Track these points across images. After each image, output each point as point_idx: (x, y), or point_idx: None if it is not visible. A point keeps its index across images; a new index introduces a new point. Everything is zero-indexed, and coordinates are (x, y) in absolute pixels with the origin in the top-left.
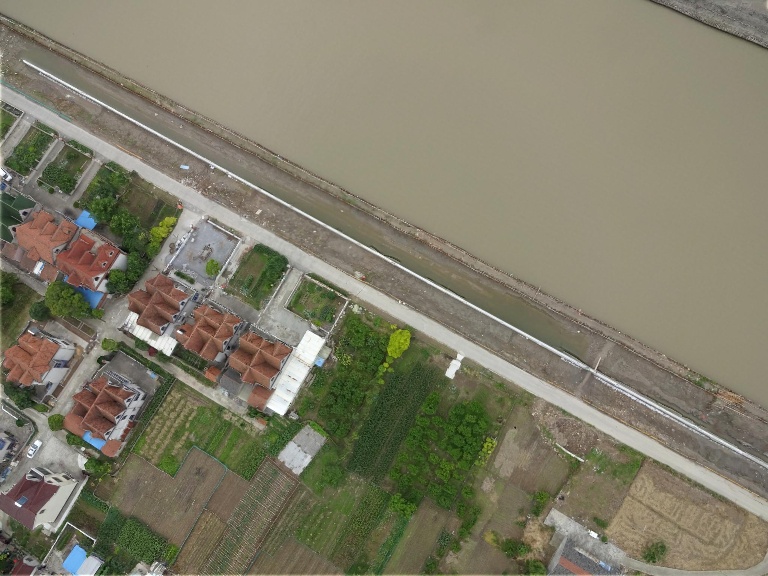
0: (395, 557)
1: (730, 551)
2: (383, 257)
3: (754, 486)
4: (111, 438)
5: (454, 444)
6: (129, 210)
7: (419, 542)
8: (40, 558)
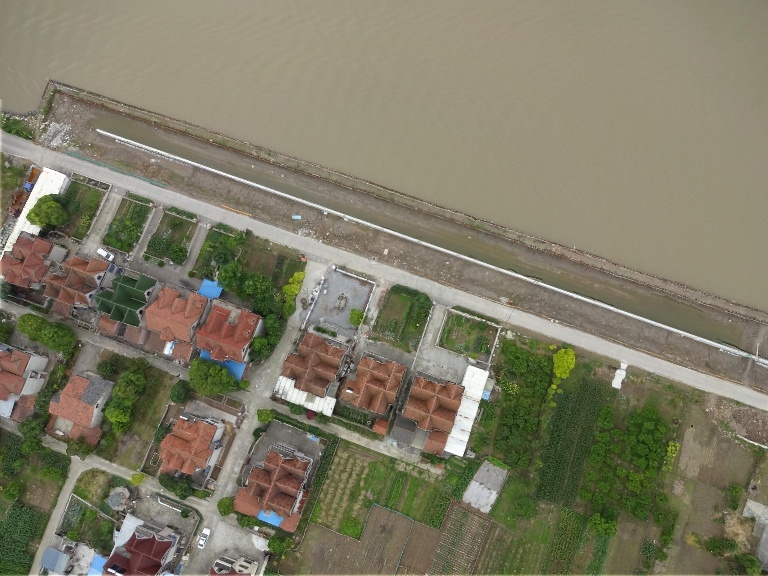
0: None
1: None
2: (524, 278)
3: None
4: None
5: (638, 454)
6: (250, 271)
7: (623, 557)
8: None
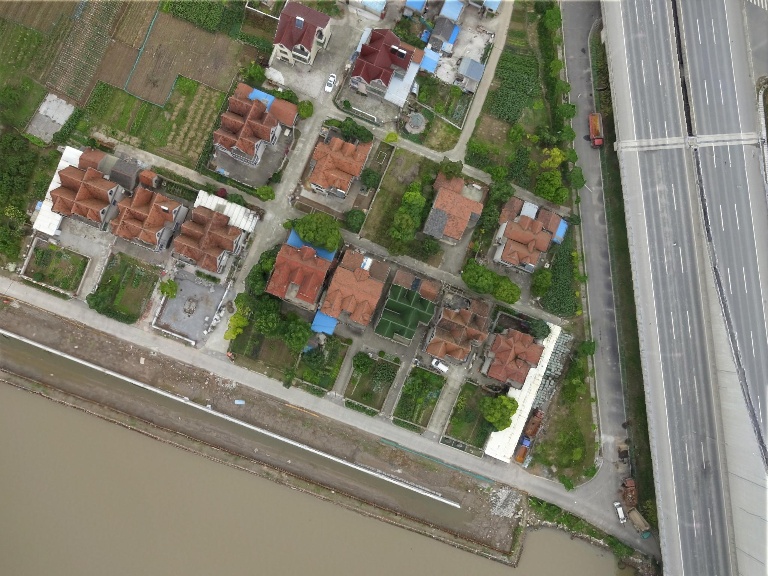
0: None
1: None
2: None
3: None
4: None
5: None
6: None
7: None
8: None
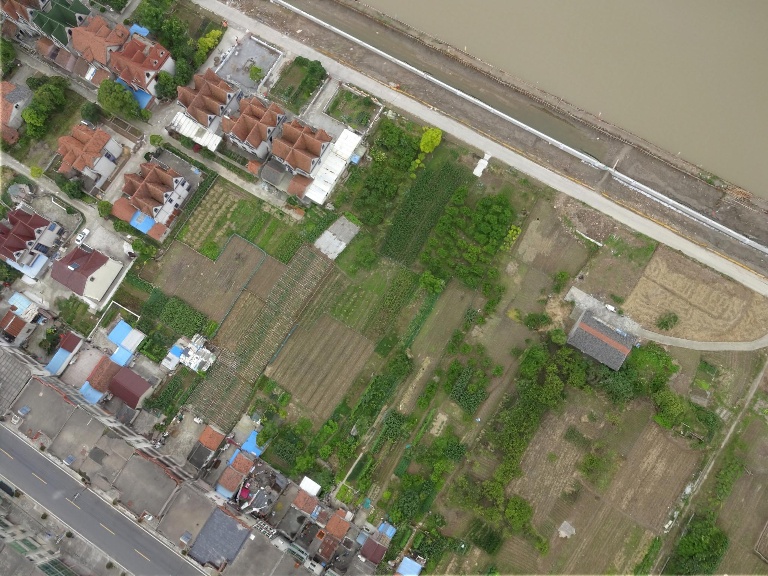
0: (424, 332)
1: (737, 324)
2: (416, 70)
3: (760, 269)
4: (157, 221)
5: (481, 231)
6: None
7: (447, 319)
8: (86, 333)
